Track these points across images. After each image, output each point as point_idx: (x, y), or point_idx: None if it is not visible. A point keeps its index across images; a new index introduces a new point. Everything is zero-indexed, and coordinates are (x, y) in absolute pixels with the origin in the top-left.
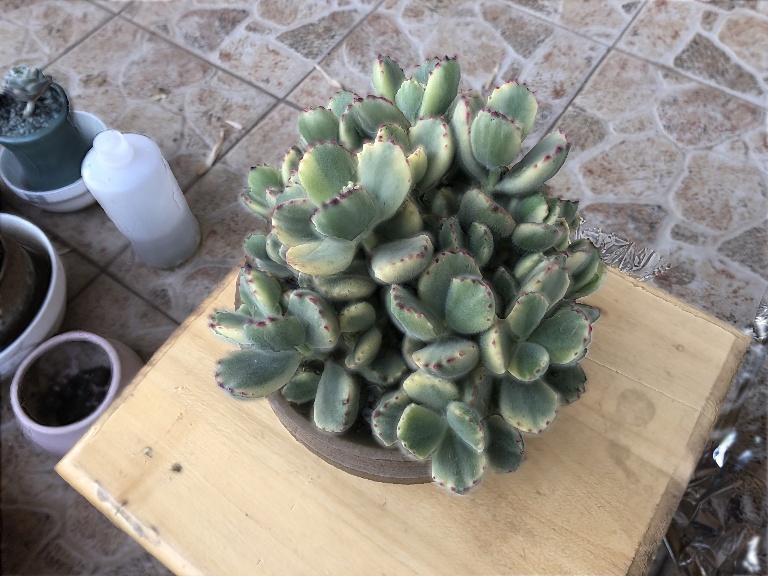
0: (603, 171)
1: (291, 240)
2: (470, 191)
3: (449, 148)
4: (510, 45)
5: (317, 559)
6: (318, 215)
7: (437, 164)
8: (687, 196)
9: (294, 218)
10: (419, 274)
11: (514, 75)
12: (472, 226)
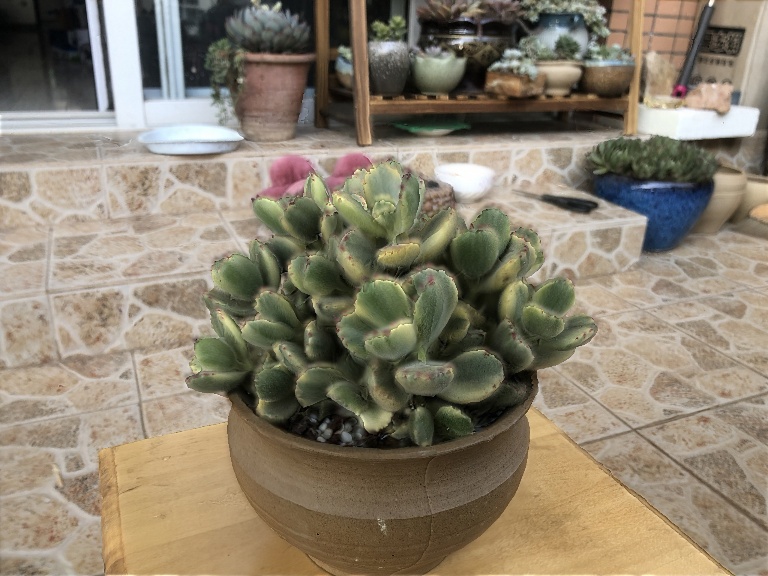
0: None
1: (361, 269)
2: None
3: None
4: (50, 447)
5: None
6: (407, 190)
7: None
8: None
9: (356, 247)
10: (455, 232)
11: (77, 463)
12: None
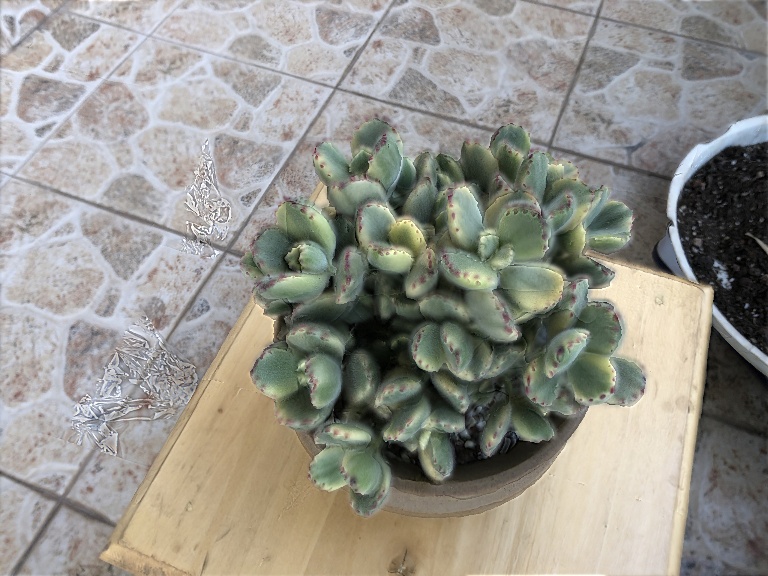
0: (18, 382)
1: None
2: (409, 205)
3: (385, 208)
4: None
5: (614, 449)
6: (548, 237)
7: (394, 224)
8: (60, 304)
9: None
10: None
11: None
12: (442, 202)
